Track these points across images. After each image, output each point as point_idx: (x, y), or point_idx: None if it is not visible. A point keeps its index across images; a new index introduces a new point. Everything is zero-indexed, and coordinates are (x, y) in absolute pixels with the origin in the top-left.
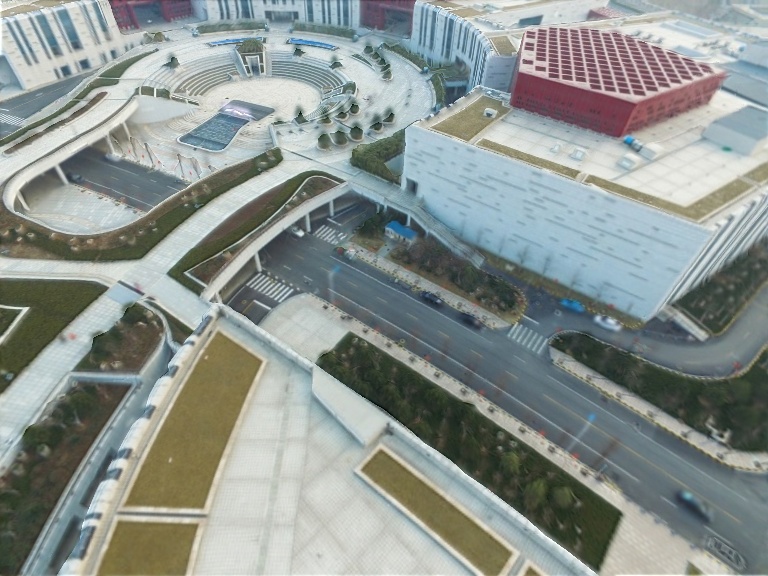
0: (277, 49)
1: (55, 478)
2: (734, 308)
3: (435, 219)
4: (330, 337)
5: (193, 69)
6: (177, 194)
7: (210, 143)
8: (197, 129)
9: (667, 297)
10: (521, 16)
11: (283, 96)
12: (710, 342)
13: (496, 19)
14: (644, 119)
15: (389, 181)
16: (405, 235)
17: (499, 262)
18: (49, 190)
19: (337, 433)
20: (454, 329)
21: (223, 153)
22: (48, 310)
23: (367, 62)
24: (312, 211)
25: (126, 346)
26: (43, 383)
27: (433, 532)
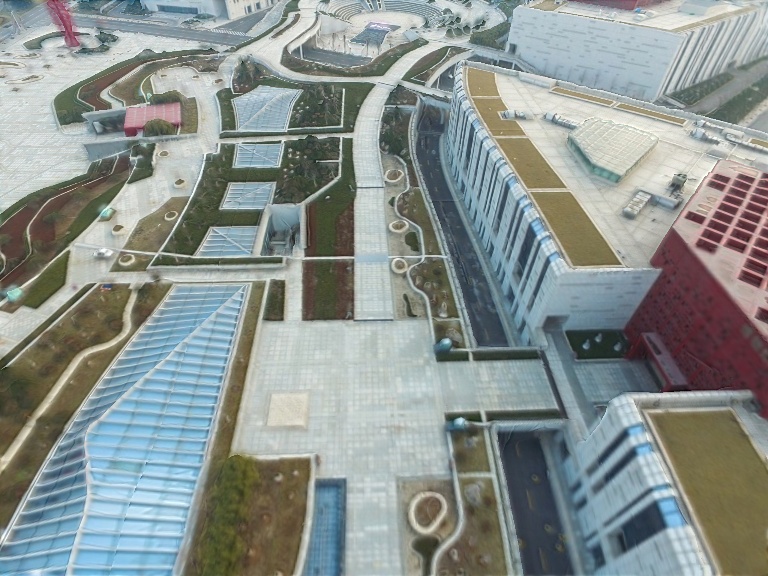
0: None
1: (403, 131)
2: (699, 97)
3: (529, 65)
4: None
5: (337, 5)
6: (383, 53)
7: None
8: (358, 36)
9: (663, 85)
10: None
11: (401, 20)
12: (686, 108)
13: None
14: (646, 1)
15: (497, 49)
16: None
17: None
18: None
19: (536, 86)
20: None
21: (382, 46)
22: (354, 90)
23: None
24: None
25: (403, 98)
26: (374, 108)
27: (585, 99)
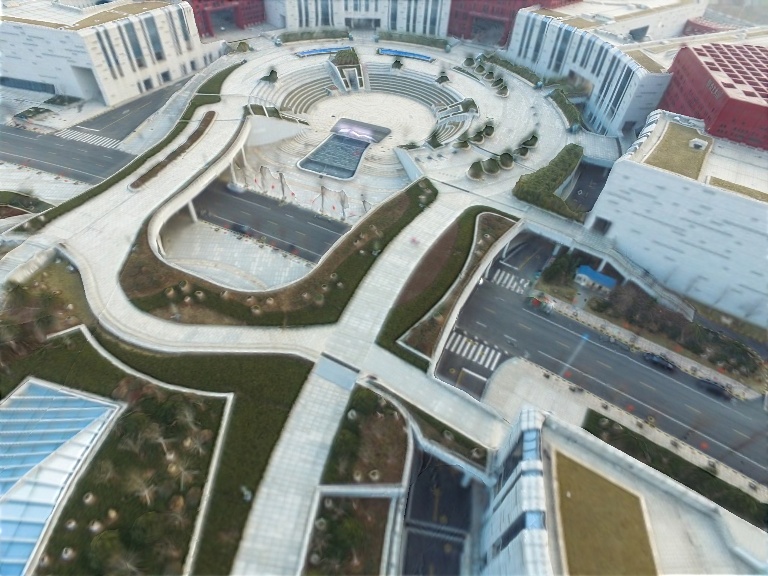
0: (371, 60)
1: None
2: None
3: (634, 264)
4: (570, 416)
5: (290, 83)
6: (344, 237)
7: (333, 169)
8: (315, 153)
9: None
10: (631, 27)
11: (392, 114)
12: None
13: (615, 31)
14: None
15: (568, 218)
16: (601, 283)
17: (712, 314)
18: (179, 229)
19: None
20: (701, 402)
21: (354, 181)
22: (256, 396)
23: (473, 76)
24: (495, 256)
25: (372, 446)
26: (290, 503)
27: None
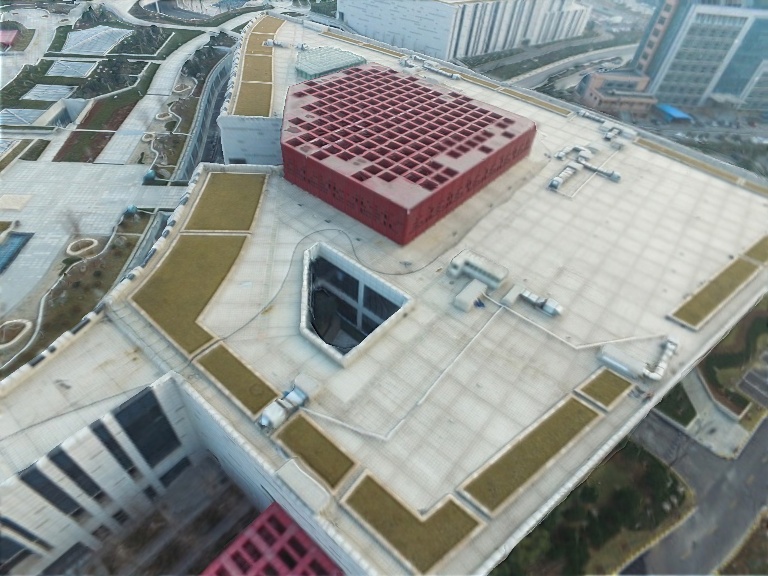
0: None
1: (210, 63)
2: (483, 62)
3: (353, 30)
4: None
5: None
6: (225, 12)
7: None
8: None
9: (450, 49)
10: None
11: None
12: None
13: None
14: None
15: (330, 16)
16: None
17: None
18: None
19: None
20: None
21: None
22: (184, 34)
23: None
24: None
25: None
26: (194, 47)
27: (342, 39)
